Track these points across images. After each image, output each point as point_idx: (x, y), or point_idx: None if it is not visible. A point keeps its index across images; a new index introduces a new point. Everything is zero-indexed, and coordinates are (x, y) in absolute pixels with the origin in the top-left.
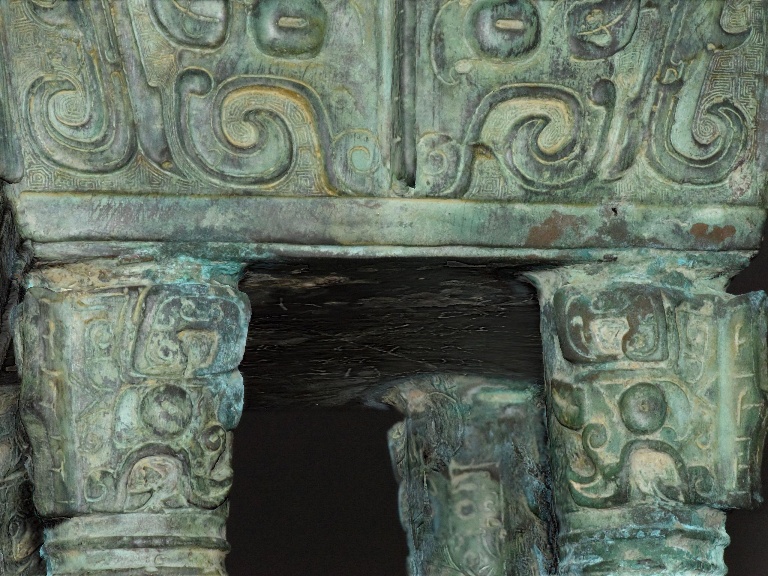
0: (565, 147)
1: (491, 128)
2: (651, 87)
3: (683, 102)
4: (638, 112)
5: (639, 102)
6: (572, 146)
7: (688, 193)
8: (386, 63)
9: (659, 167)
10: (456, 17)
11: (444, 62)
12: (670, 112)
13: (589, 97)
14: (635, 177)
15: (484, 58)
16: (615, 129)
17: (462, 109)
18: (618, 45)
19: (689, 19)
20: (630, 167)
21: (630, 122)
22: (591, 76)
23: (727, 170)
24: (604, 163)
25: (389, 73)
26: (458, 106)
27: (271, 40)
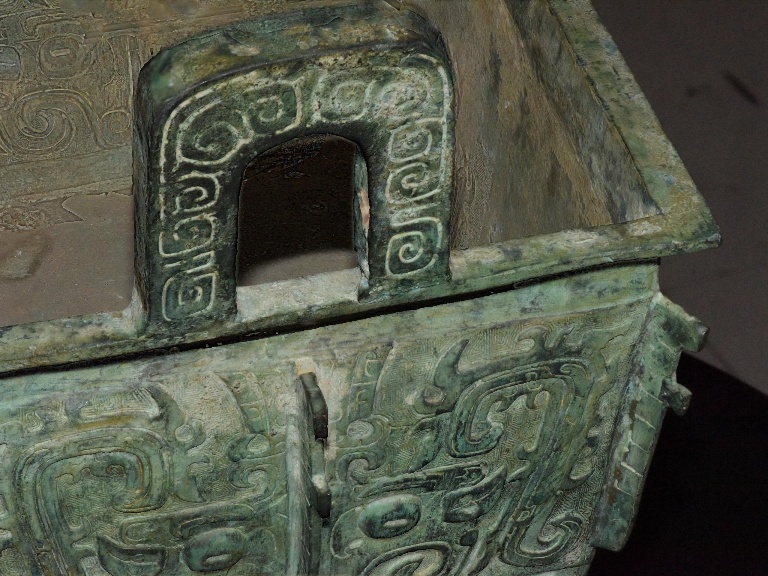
0: (434, 572)
1: (376, 572)
2: (508, 522)
3: (533, 526)
4: (495, 538)
5: (497, 533)
6: (440, 571)
7: (530, 569)
8: (293, 555)
9: (508, 563)
10: (352, 518)
11: (340, 547)
12: (521, 536)
13: (457, 543)
14: (488, 570)
15: (373, 538)
16: (476, 548)
17: (353, 571)
18: (484, 512)
19: (544, 481)
20: (485, 567)
21: (488, 545)
22: (459, 531)
23: (563, 555)
24: (465, 568)
25: (295, 562)
26: (350, 569)
27: (200, 570)
